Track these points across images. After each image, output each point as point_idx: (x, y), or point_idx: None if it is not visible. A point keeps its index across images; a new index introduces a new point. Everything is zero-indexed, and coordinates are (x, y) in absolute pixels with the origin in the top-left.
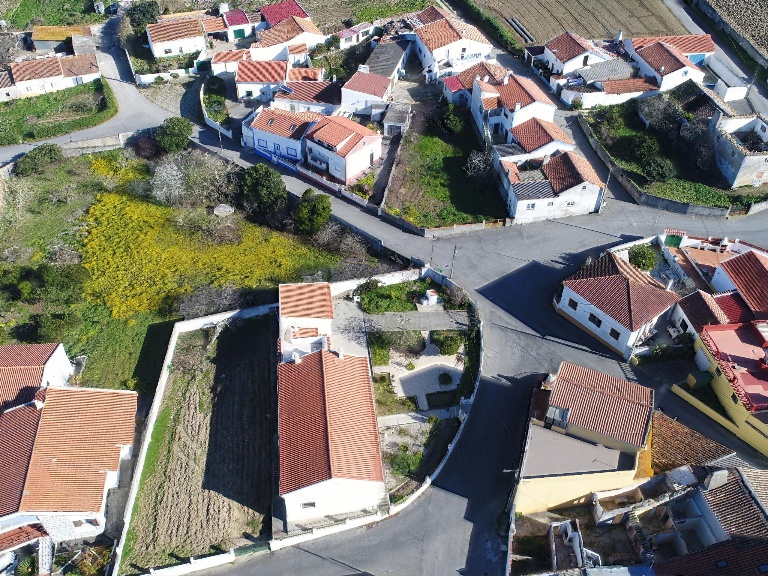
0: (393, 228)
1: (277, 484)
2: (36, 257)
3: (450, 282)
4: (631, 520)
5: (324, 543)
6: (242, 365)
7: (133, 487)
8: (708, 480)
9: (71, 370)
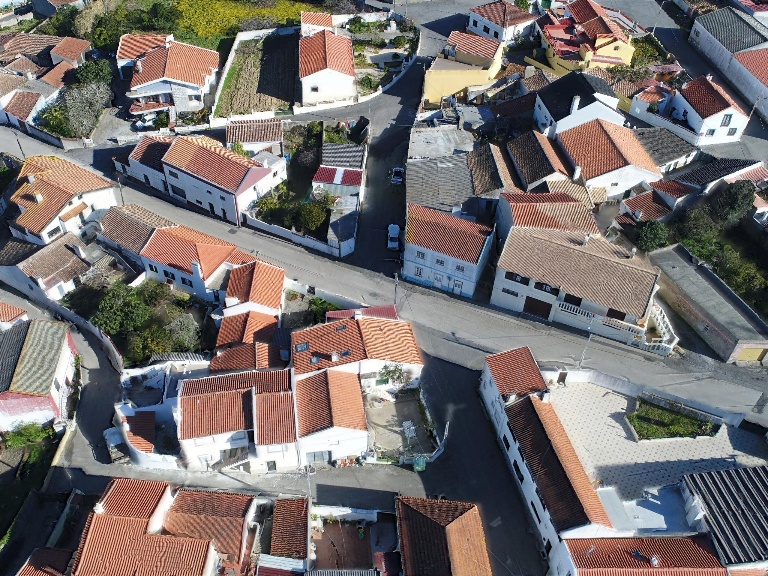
0: (374, 0)
1: (298, 92)
2: None
3: (405, 18)
4: (484, 95)
5: (322, 112)
6: (278, 52)
7: (219, 87)
8: (524, 72)
9: None
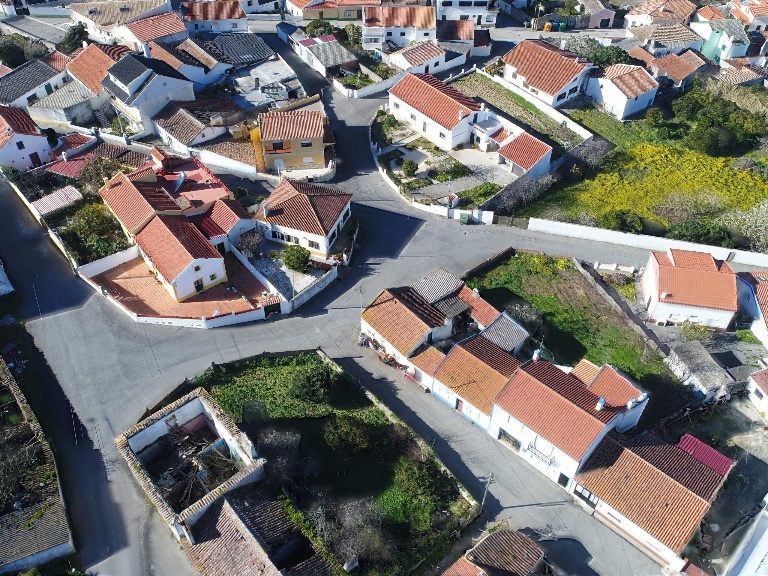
0: None
1: None
2: (764, 159)
3: None
4: None
5: None
6: None
7: (506, 81)
8: None
9: (619, 117)
